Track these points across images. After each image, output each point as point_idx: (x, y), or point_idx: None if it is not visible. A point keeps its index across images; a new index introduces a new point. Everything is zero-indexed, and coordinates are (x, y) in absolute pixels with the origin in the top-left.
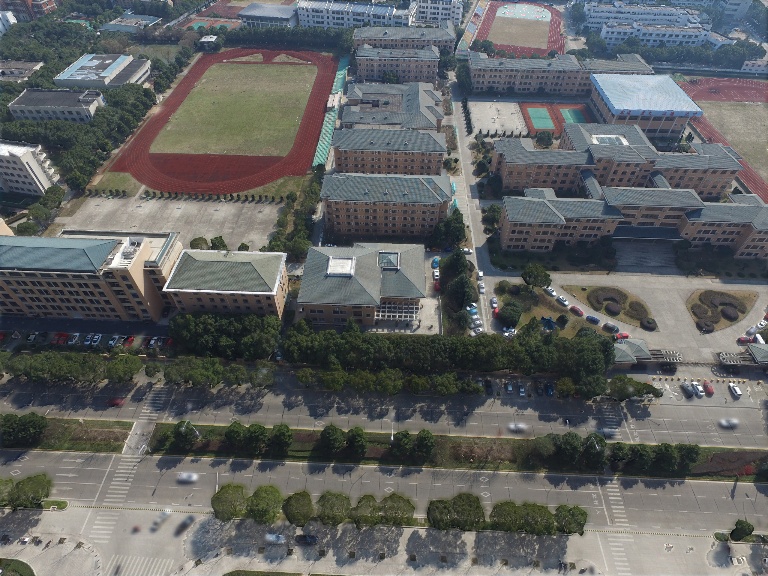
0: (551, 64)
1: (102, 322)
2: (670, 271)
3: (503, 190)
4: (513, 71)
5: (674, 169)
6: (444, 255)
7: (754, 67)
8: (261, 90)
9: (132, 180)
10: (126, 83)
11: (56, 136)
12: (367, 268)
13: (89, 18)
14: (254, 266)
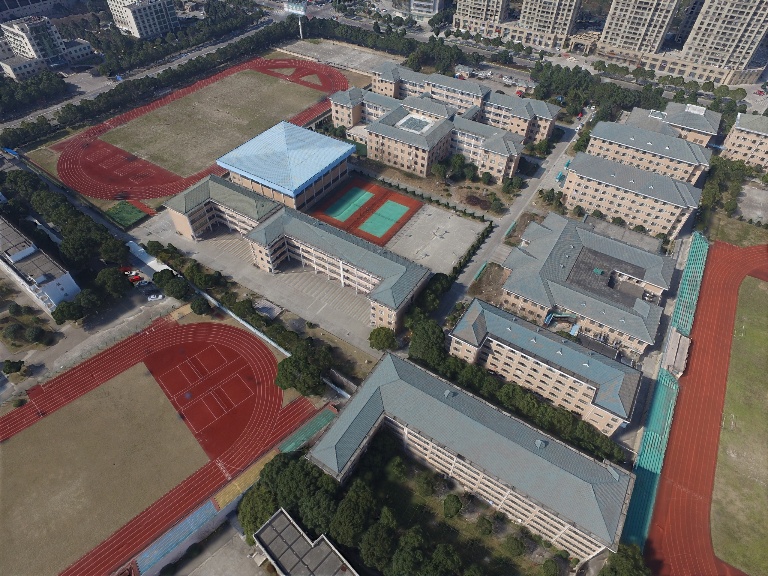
0: None
1: None
2: None
3: None
4: None
5: None
6: None
7: None
8: None
9: None
10: None
11: None
12: None
13: None
14: None
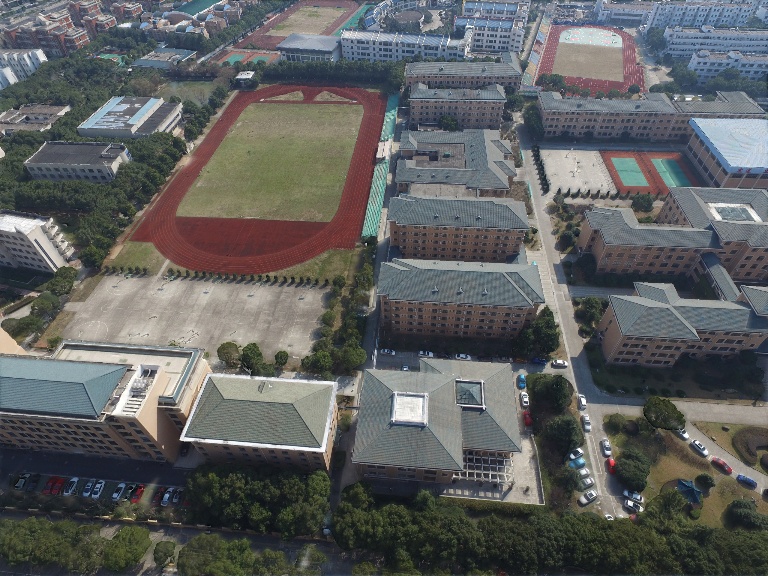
0: (640, 106)
1: (107, 460)
2: None
3: (597, 272)
4: (593, 114)
5: None
6: (531, 368)
7: None
8: (301, 136)
9: (155, 253)
10: (154, 132)
11: (73, 200)
12: (443, 409)
13: (122, 52)
14: (297, 409)
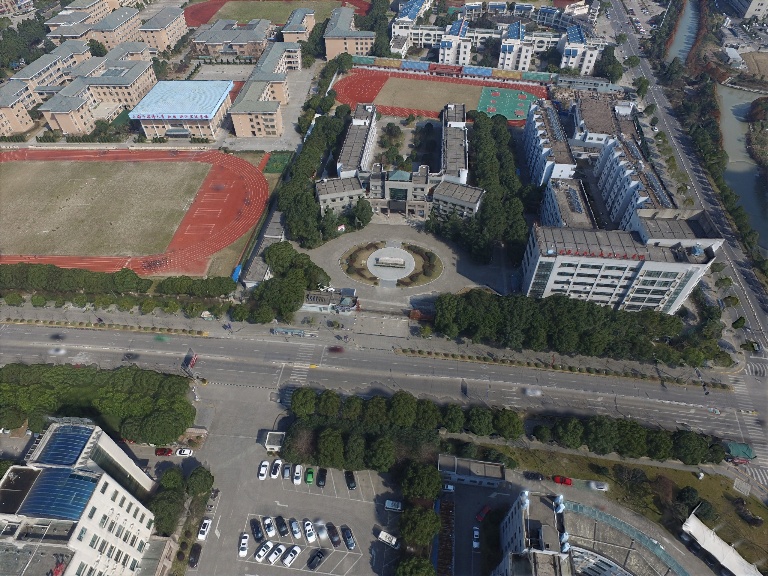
0: (258, 66)
1: None
2: None
3: None
4: None
5: None
6: None
7: None
8: None
9: None
10: None
11: None
12: (64, 18)
13: None
14: None
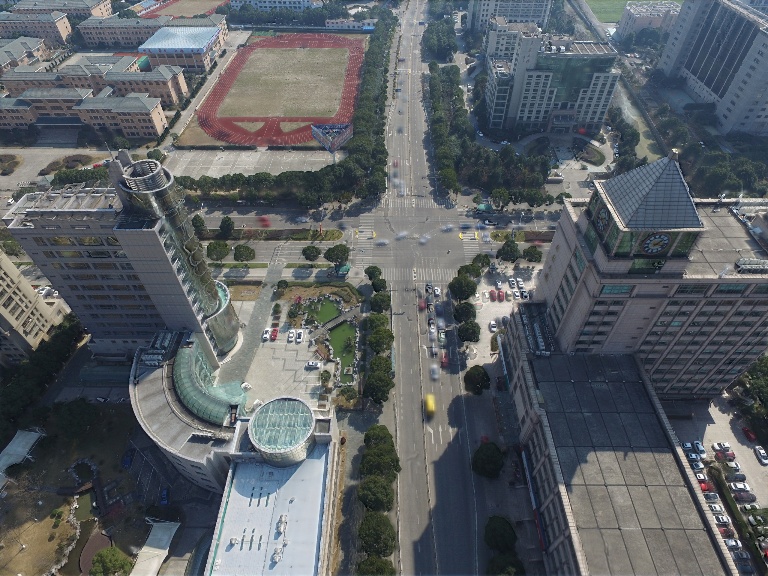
0: (139, 22)
1: None
2: (69, 146)
3: None
4: (111, 28)
5: (121, 82)
6: None
7: (334, 24)
8: None
9: None
10: None
11: None
12: None
13: None
14: None
